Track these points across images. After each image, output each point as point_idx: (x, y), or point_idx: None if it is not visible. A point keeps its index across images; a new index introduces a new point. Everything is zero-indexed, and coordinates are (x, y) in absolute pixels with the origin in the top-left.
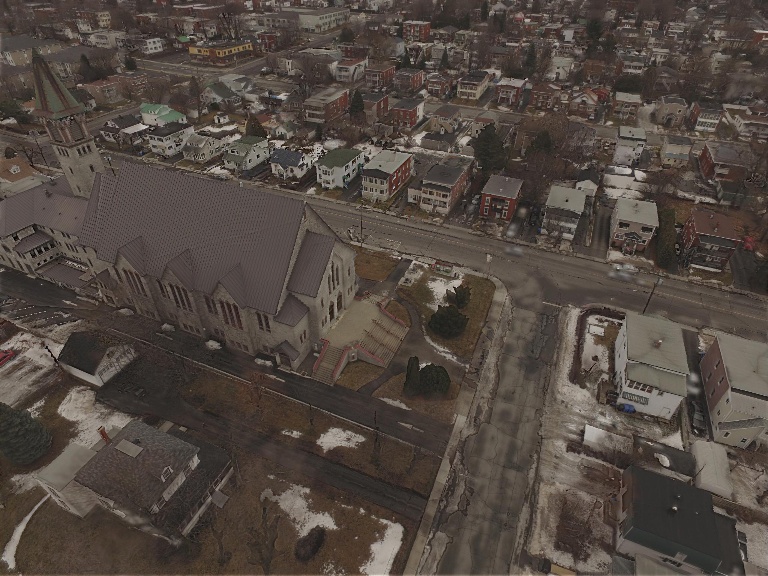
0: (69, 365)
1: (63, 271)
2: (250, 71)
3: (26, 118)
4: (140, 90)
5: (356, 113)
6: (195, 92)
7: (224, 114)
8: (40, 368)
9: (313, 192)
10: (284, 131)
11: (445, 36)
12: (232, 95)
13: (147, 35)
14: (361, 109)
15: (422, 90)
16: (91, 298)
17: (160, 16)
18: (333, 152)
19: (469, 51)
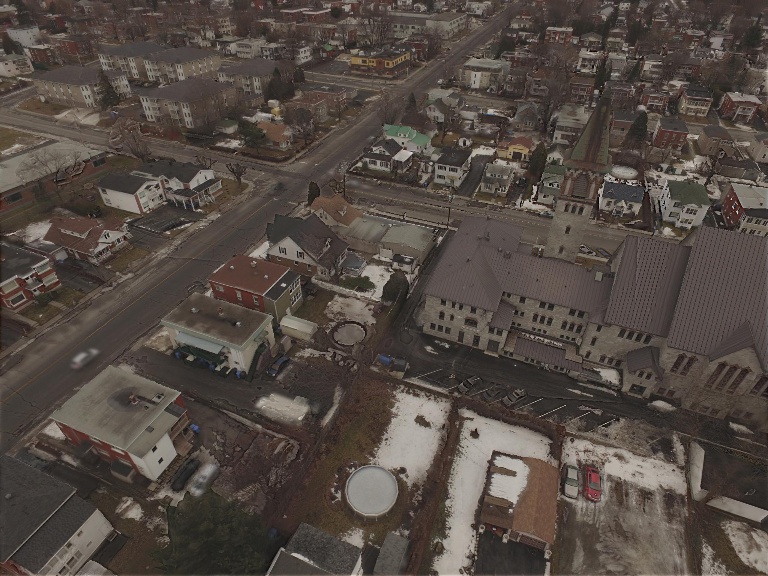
0: (727, 497)
1: (536, 348)
2: (425, 83)
3: (257, 141)
4: (340, 107)
5: (639, 137)
6: (412, 110)
7: (469, 136)
8: (650, 493)
9: (672, 233)
10: (558, 156)
11: (595, 44)
12: (454, 113)
13: (297, 44)
14: (644, 132)
15: (640, 106)
16: (598, 385)
17: (285, 22)
18: (688, 187)
19: (664, 62)
